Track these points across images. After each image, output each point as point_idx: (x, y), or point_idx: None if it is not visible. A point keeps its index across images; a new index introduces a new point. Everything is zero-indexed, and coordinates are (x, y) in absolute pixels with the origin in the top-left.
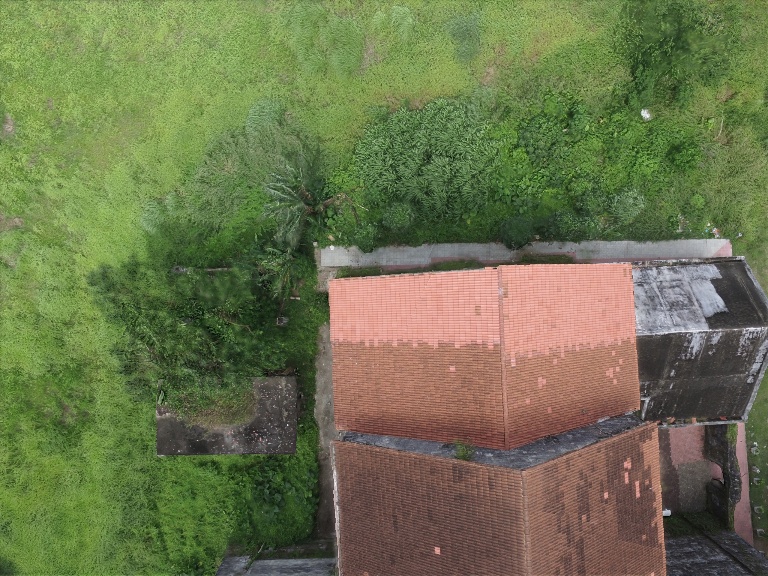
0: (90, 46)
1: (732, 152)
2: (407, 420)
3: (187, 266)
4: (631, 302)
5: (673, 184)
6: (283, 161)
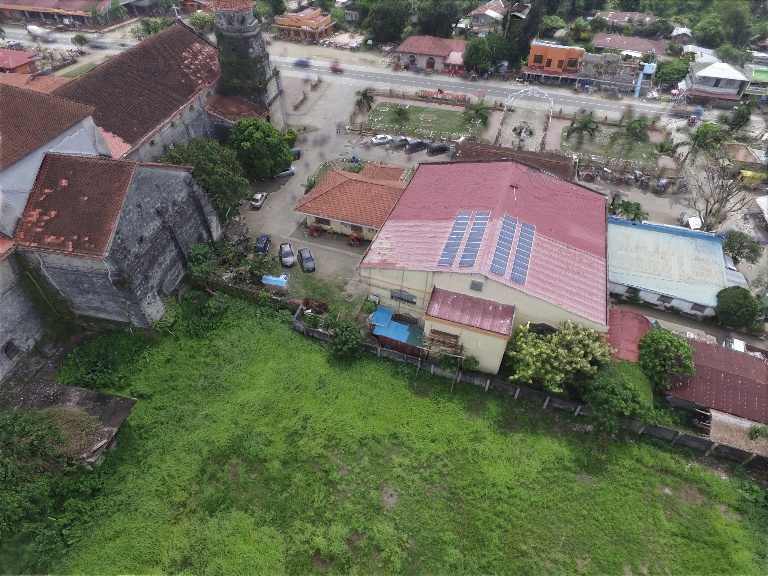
0: None
1: None
2: None
3: None
4: None
5: None
6: None
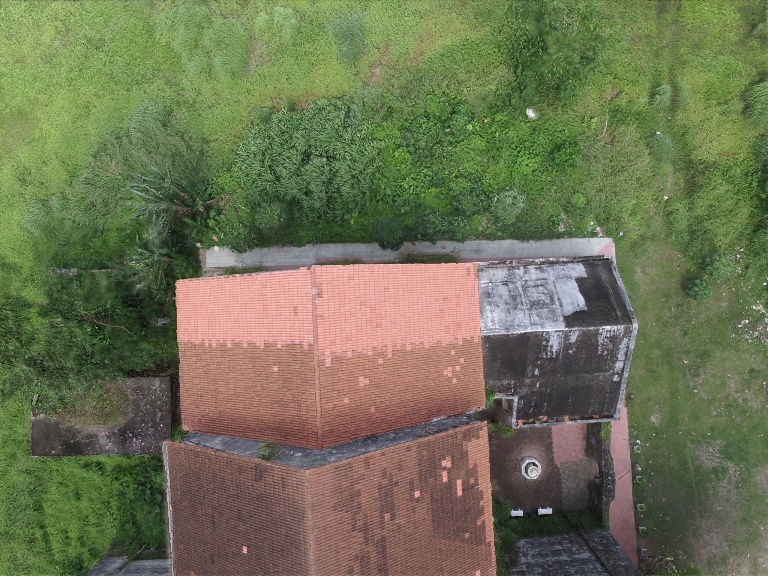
0: None
1: (614, 151)
2: (239, 420)
3: (73, 267)
4: (476, 301)
5: (555, 183)
6: (166, 162)
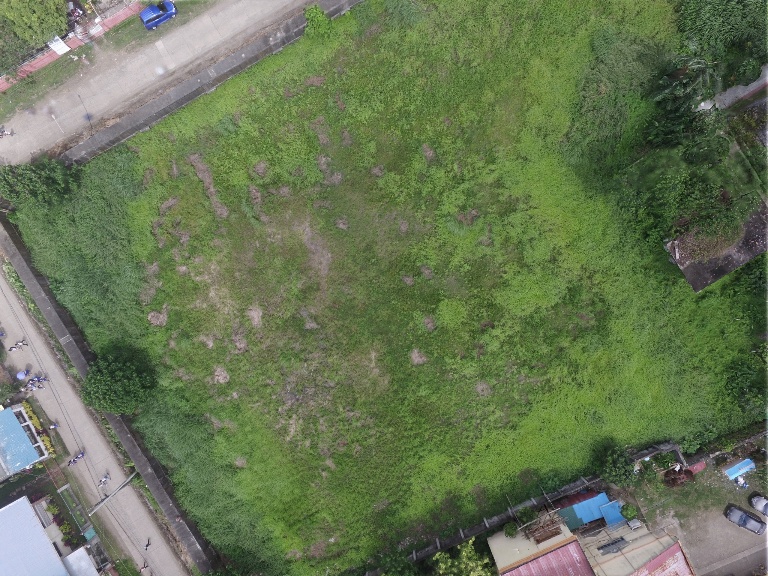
0: (452, 67)
1: None
2: None
3: (609, 175)
4: None
5: None
6: (639, 64)
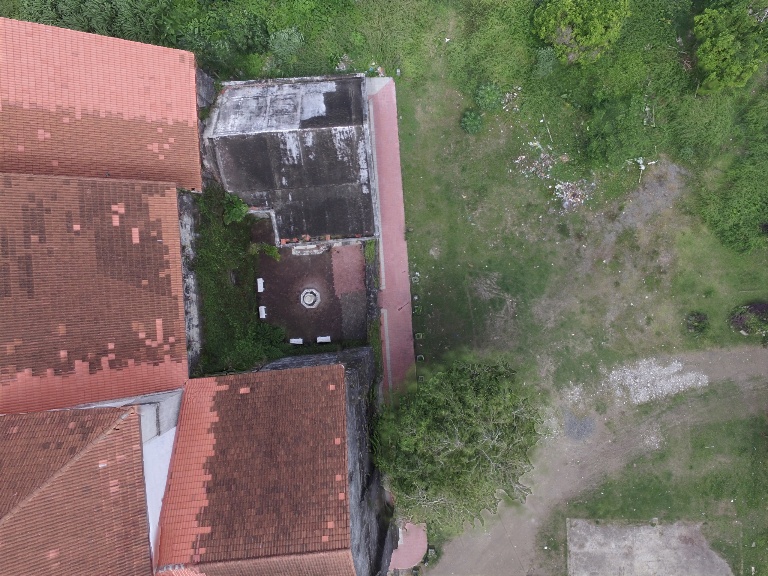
0: None
1: None
2: None
3: None
4: (191, 88)
5: (334, 23)
6: None
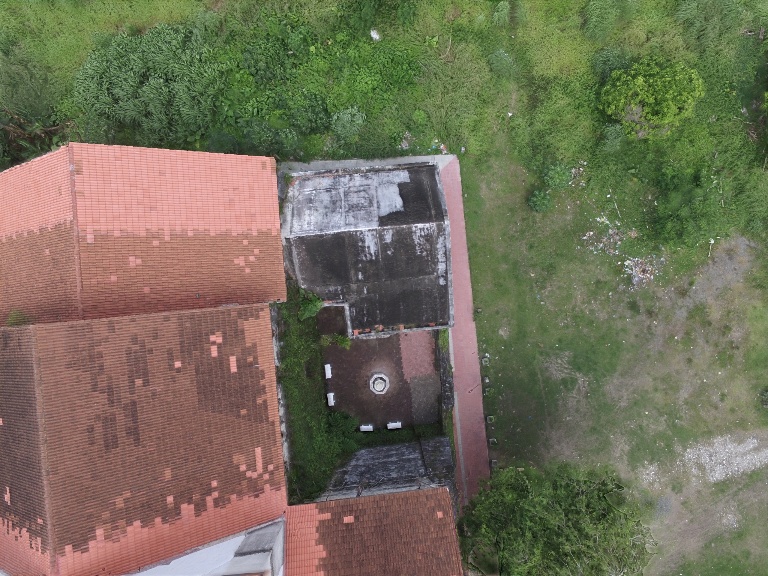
0: None
1: (454, 68)
2: (24, 310)
3: None
4: (274, 195)
5: (396, 101)
6: (9, 91)
